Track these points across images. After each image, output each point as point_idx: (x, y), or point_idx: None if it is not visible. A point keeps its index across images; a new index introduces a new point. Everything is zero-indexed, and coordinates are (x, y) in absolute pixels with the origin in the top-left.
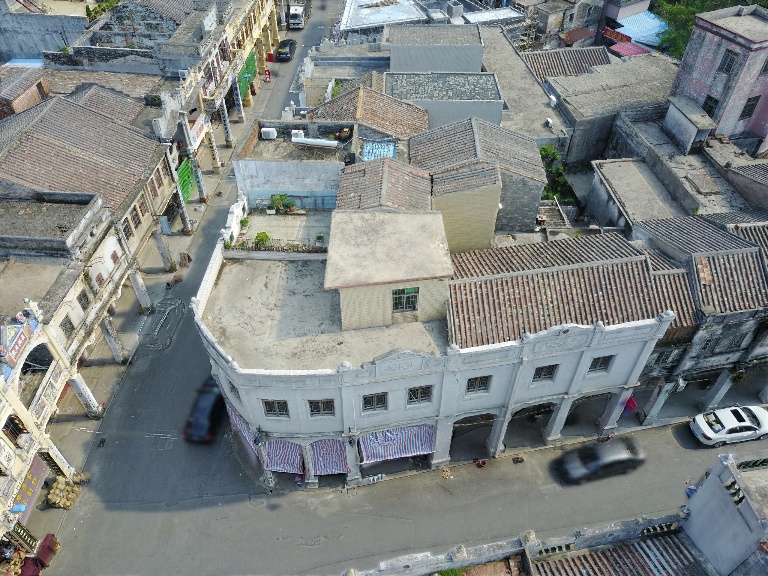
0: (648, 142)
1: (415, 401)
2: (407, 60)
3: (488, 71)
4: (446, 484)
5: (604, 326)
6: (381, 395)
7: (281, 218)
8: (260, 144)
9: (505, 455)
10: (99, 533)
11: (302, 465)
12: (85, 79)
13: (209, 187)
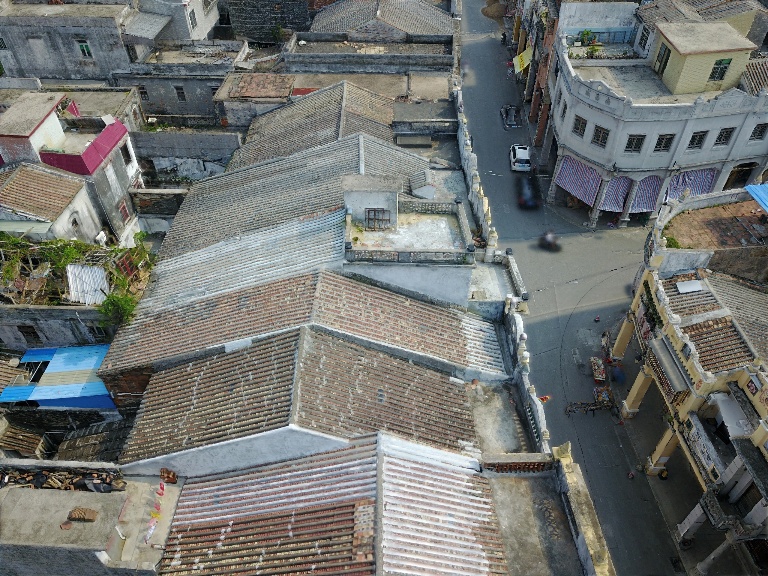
0: None
1: (718, 144)
2: None
3: None
4: None
5: None
6: (702, 135)
7: (586, 48)
8: None
9: None
10: None
11: (623, 205)
12: None
13: None
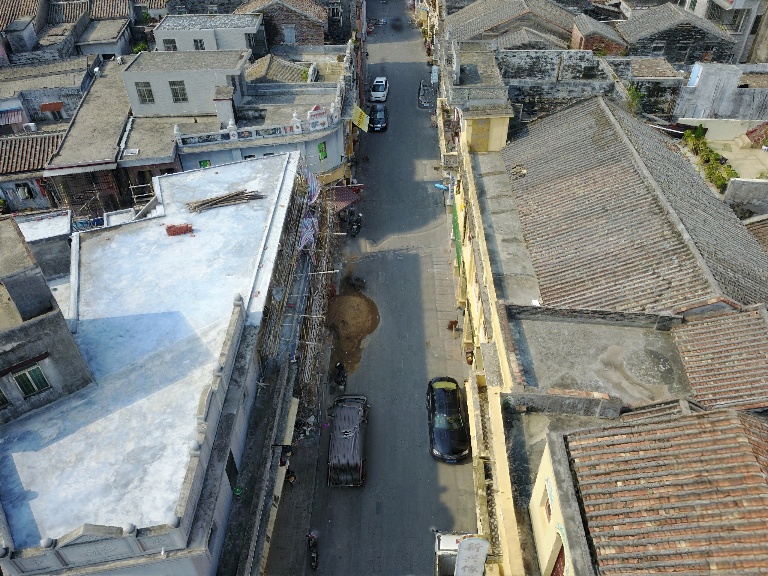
0: None
1: None
2: None
3: None
4: None
5: None
6: None
7: None
8: None
9: None
10: None
11: None
12: None
13: None
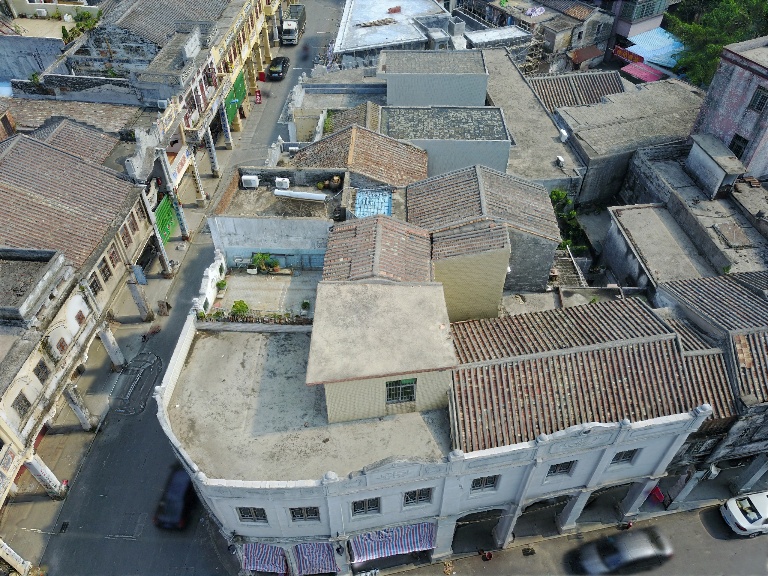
0: (670, 186)
1: (412, 502)
2: (405, 90)
3: (493, 100)
4: None
5: (630, 420)
6: (373, 499)
7: (263, 279)
8: (240, 193)
9: (514, 545)
10: None
11: (285, 564)
12: (56, 110)
13: (193, 223)
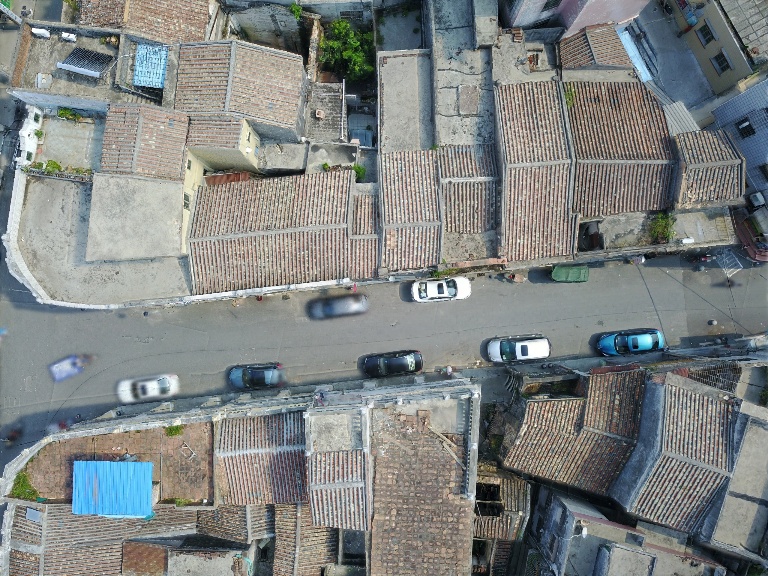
0: None
1: None
2: None
3: None
4: (233, 310)
5: None
6: None
7: (72, 125)
8: (36, 44)
9: (277, 293)
10: (10, 322)
11: None
12: None
13: None
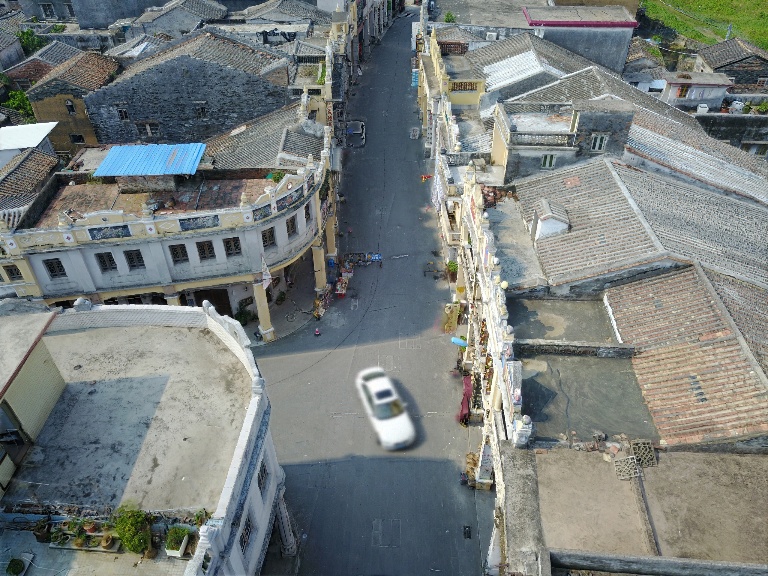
0: None
1: None
2: None
3: None
4: None
5: None
6: None
7: None
8: None
9: None
10: (426, 433)
11: None
12: None
13: None
